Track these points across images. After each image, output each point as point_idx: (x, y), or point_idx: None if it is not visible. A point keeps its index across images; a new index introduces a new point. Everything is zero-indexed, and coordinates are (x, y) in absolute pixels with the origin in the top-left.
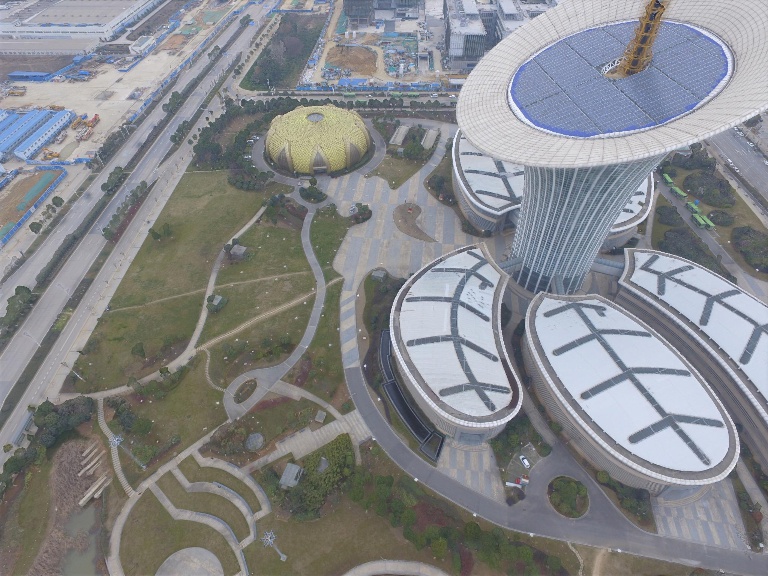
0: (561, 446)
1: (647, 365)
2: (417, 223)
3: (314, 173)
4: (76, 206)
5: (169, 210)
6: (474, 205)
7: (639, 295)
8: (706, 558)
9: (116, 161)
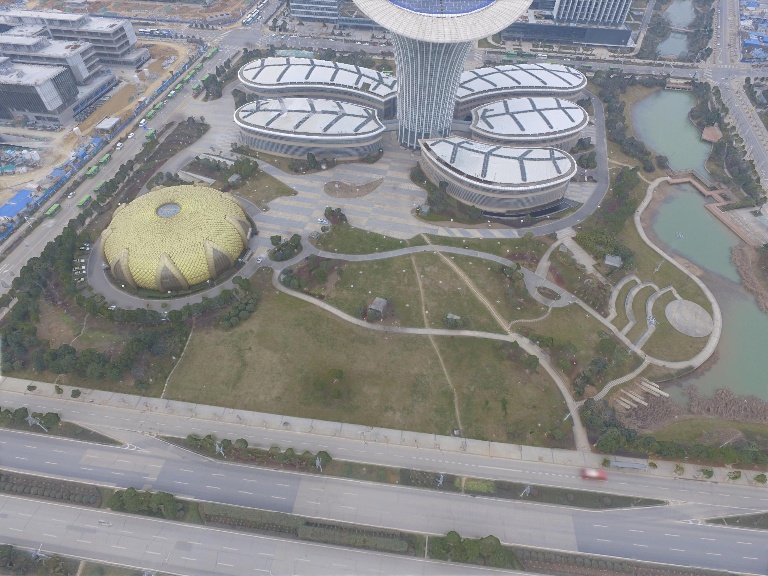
0: None
1: None
2: (355, 185)
3: (247, 245)
4: (195, 569)
5: (264, 401)
6: (363, 141)
7: (471, 98)
8: (602, 136)
9: (49, 537)
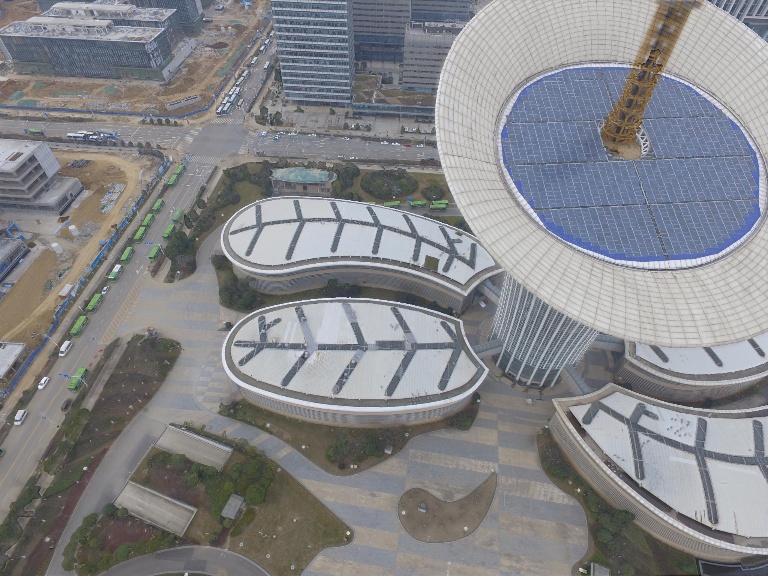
0: (762, 392)
1: None
2: (452, 499)
3: None
4: None
5: None
6: None
7: None
8: None
9: None
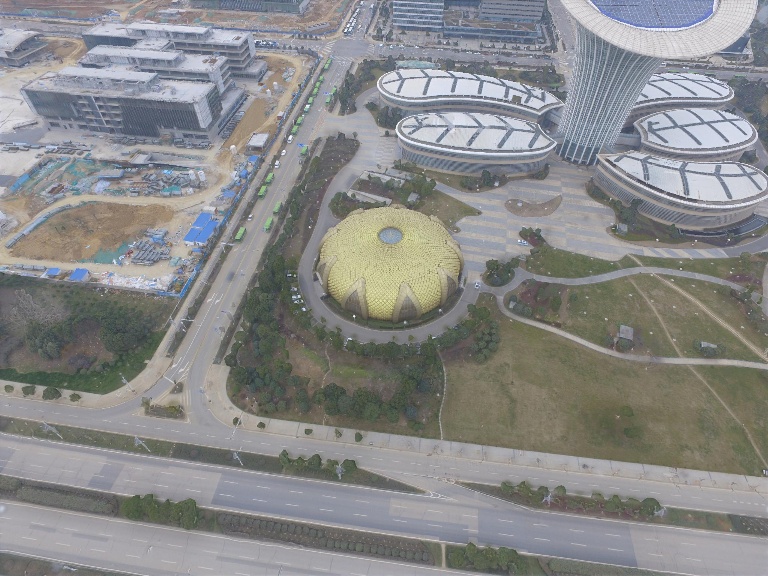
0: None
1: (695, 117)
2: (536, 203)
3: None
4: None
5: (551, 441)
6: (536, 156)
7: None
8: (760, 148)
9: None
